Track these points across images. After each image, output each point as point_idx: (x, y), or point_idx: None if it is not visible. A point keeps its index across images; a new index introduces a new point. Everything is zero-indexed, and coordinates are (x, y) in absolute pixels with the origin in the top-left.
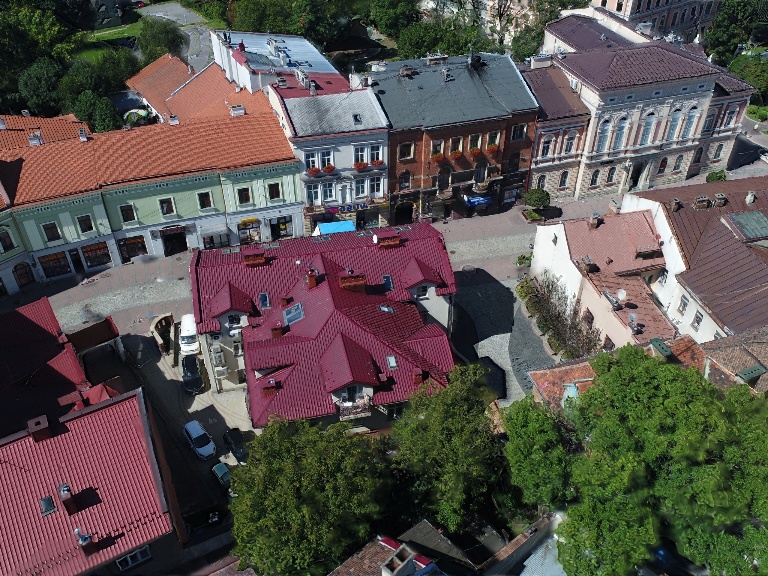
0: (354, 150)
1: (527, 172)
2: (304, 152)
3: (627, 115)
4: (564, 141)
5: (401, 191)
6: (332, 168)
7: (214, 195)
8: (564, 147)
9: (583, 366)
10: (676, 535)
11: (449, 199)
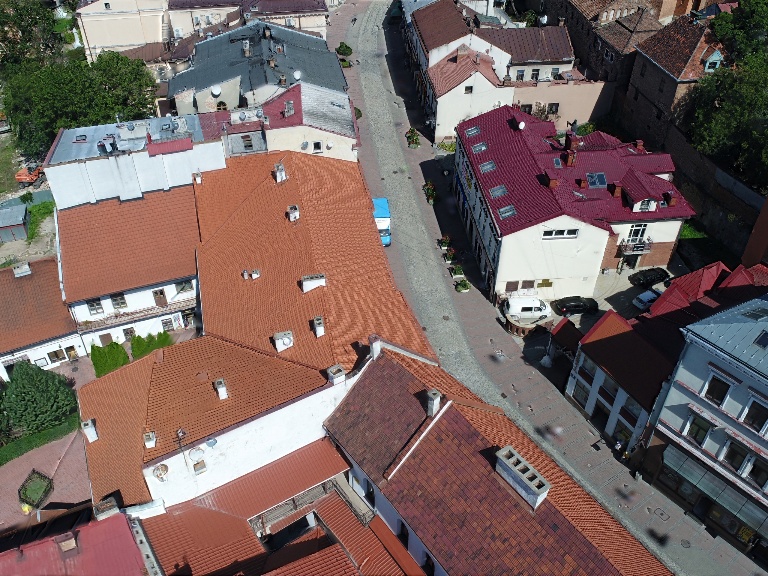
0: None
1: None
2: None
3: None
4: None
5: None
6: None
7: None
8: None
9: (697, 50)
10: None
11: None
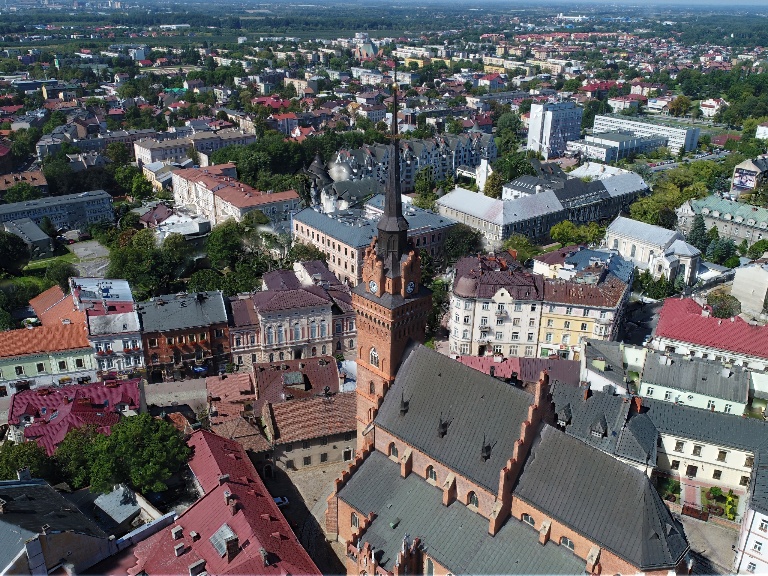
0: (123, 342)
1: (229, 354)
2: (95, 343)
3: (282, 324)
4: (249, 338)
5: (153, 364)
6: (111, 351)
7: (46, 365)
8: (249, 341)
9: None
10: (130, 471)
11: (182, 368)
